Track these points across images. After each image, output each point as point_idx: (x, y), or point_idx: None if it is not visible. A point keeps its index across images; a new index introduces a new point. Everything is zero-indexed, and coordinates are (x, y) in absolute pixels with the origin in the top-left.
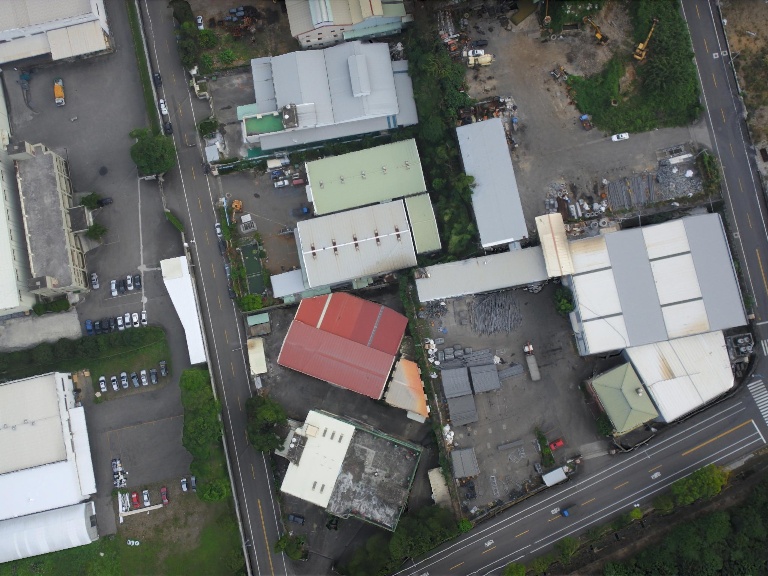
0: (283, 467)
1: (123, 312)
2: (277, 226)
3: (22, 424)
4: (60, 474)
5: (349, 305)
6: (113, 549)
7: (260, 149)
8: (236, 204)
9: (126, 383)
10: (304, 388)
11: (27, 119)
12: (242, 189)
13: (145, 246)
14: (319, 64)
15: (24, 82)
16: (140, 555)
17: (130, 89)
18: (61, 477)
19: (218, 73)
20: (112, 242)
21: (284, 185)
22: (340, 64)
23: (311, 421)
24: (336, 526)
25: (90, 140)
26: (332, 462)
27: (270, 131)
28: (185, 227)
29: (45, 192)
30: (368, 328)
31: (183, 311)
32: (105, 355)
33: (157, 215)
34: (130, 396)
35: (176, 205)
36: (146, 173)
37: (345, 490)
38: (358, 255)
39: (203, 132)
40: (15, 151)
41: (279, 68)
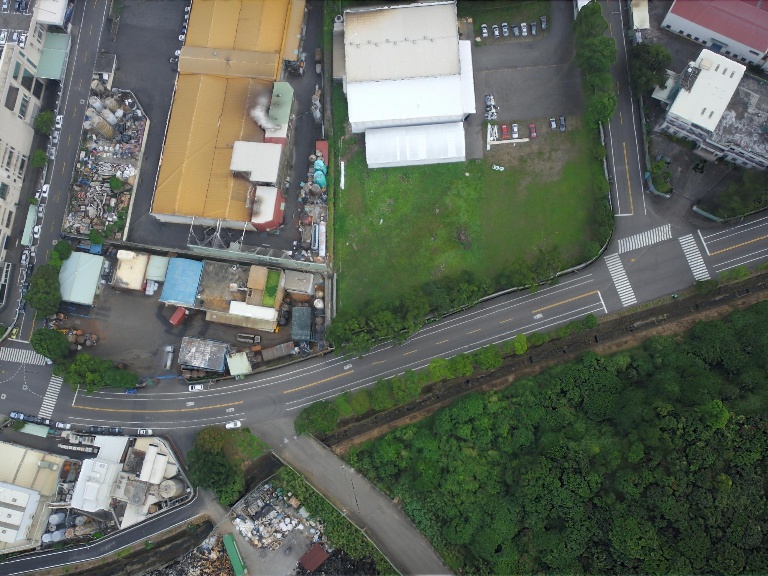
0: (653, 115)
1: None
2: None
3: (422, 40)
4: (450, 87)
5: None
6: (478, 171)
7: None
8: None
9: (507, 31)
10: (679, 51)
11: None
12: None
13: None
14: None
15: None
16: (503, 179)
17: None
18: (450, 90)
19: None
20: None
21: None
22: None
23: (705, 57)
24: (702, 170)
25: None
26: (723, 93)
27: None
28: None
29: None
30: None
31: None
32: (489, 6)
33: None
34: (508, 44)
35: None
36: None
37: (727, 125)
38: None
39: None
40: None
41: None
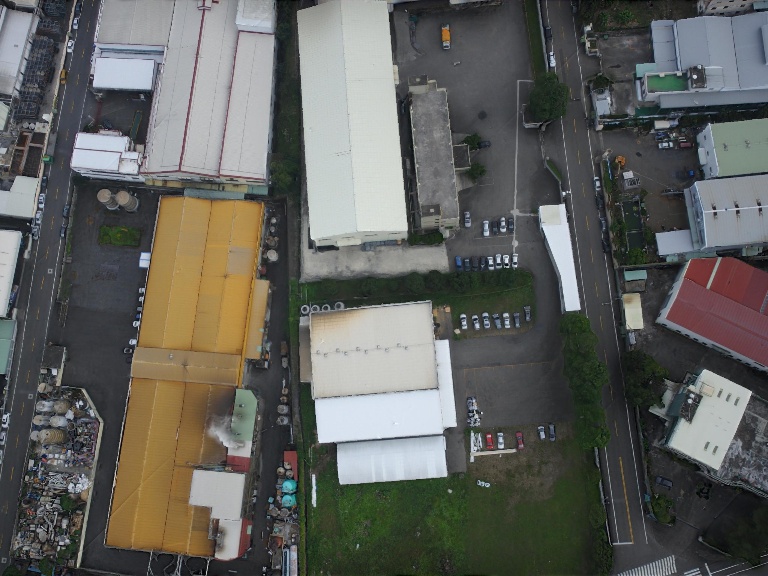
0: (651, 427)
1: (493, 253)
2: (659, 186)
3: (395, 347)
4: (427, 402)
5: (739, 271)
6: (462, 487)
7: (649, 109)
8: (620, 160)
9: (488, 323)
10: (677, 350)
11: (411, 59)
12: (624, 147)
13: (520, 191)
14: (727, 31)
15: (413, 24)
16: (489, 497)
17: (515, 40)
18: (428, 405)
19: (611, 32)
20: (486, 184)
21: (669, 147)
22: (750, 32)
23: (706, 380)
24: (707, 495)
25: (471, 85)
26: (728, 424)
27: (671, 90)
28: (562, 177)
29: (435, 126)
30: (760, 296)
31: (560, 258)
32: (468, 293)
33: (535, 163)
34: (490, 337)
35: (555, 155)
36: (533, 120)
37: (733, 456)
38: (760, 220)
39: (594, 86)
40: (417, 83)
41: (686, 30)
